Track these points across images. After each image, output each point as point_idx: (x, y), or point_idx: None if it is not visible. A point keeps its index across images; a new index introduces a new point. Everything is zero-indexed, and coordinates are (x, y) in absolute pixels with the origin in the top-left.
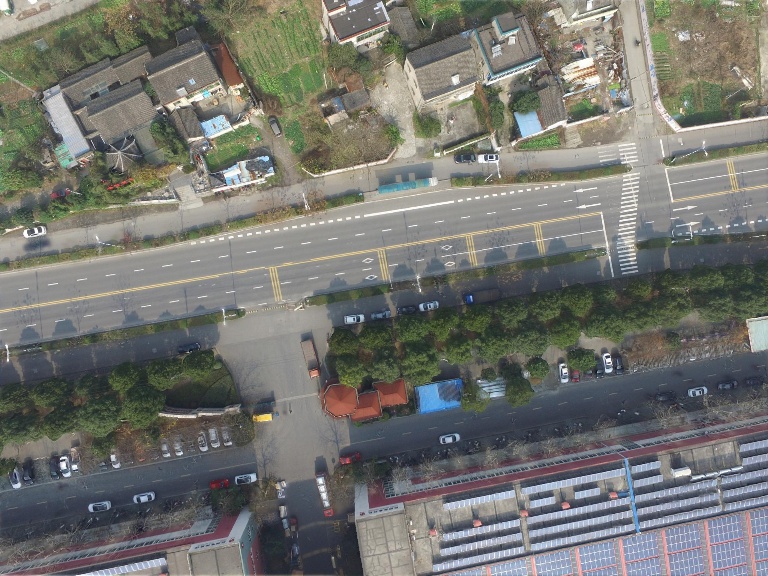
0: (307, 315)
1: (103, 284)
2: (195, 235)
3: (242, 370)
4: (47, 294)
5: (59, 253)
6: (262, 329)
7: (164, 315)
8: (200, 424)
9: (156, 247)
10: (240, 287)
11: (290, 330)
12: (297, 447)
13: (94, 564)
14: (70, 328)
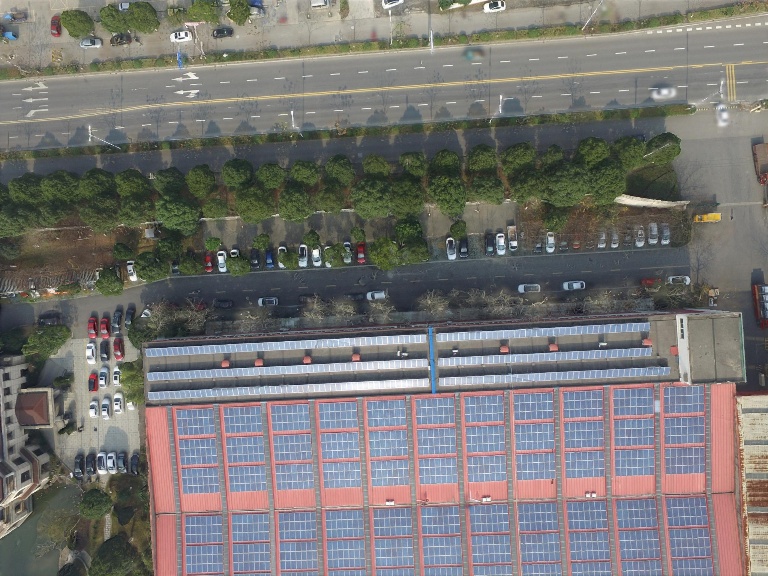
0: (760, 119)
1: (554, 66)
2: (657, 22)
3: (685, 169)
4: (498, 71)
5: (515, 30)
6: (710, 129)
7: (612, 103)
8: (650, 213)
9: (612, 32)
10: (693, 82)
11: (740, 133)
12: (734, 256)
13: (576, 320)
14: (517, 107)
